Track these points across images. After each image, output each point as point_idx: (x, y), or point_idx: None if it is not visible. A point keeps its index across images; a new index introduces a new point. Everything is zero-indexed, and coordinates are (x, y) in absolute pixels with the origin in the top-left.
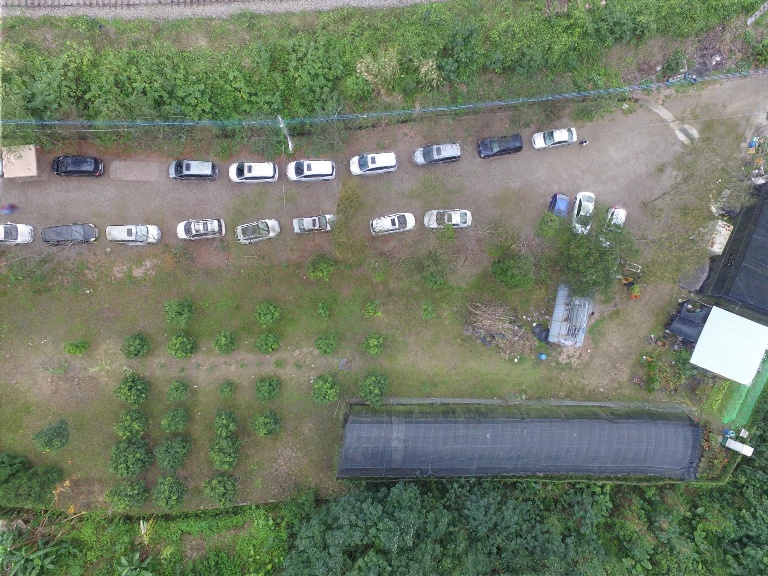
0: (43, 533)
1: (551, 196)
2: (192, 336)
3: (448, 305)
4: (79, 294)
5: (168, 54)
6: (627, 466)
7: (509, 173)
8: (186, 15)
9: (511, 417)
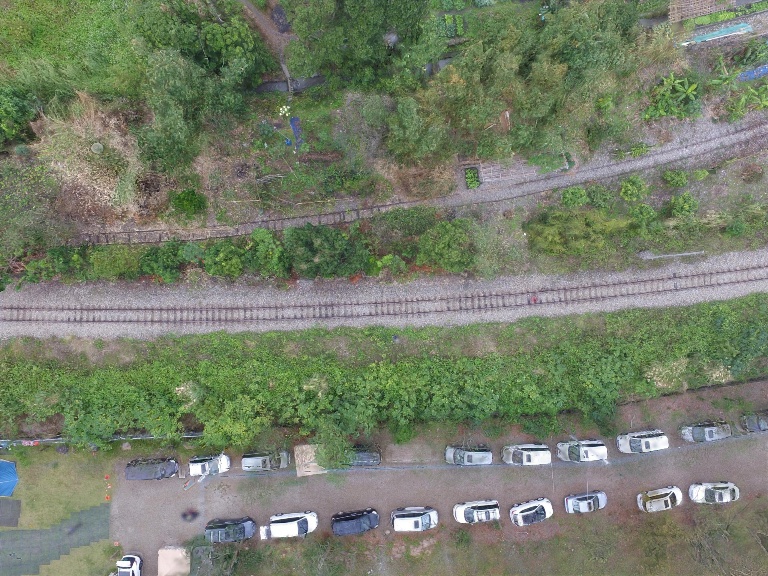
0: None
1: None
2: None
3: (711, 572)
4: (360, 575)
5: (468, 370)
6: None
7: None
8: (474, 320)
9: None
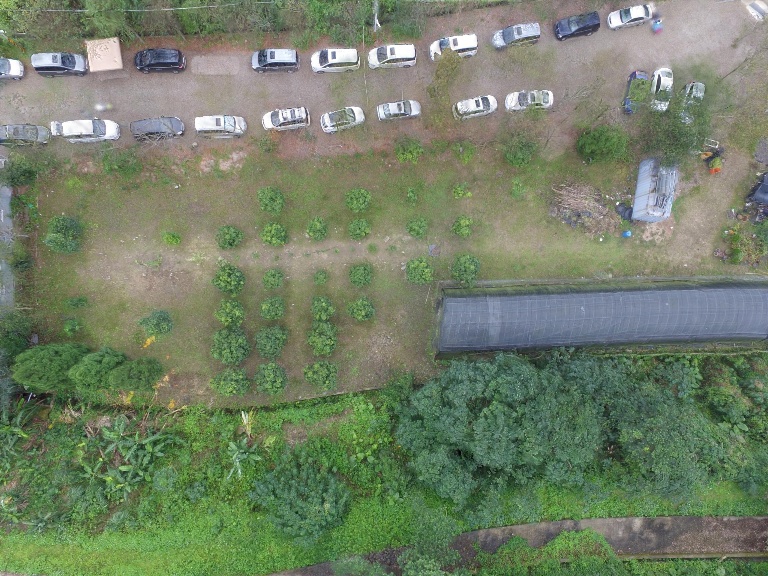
0: (147, 426)
1: (628, 75)
2: None
3: (532, 188)
4: (168, 190)
5: None
6: (718, 334)
7: (586, 54)
8: None
9: (603, 290)
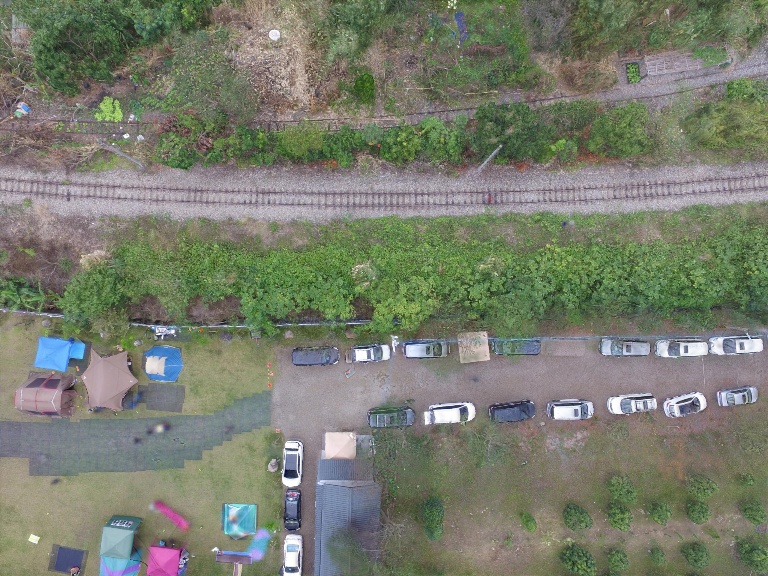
0: None
1: None
2: (622, 504)
3: None
4: (515, 466)
5: (639, 254)
6: None
7: None
8: (640, 209)
9: None
